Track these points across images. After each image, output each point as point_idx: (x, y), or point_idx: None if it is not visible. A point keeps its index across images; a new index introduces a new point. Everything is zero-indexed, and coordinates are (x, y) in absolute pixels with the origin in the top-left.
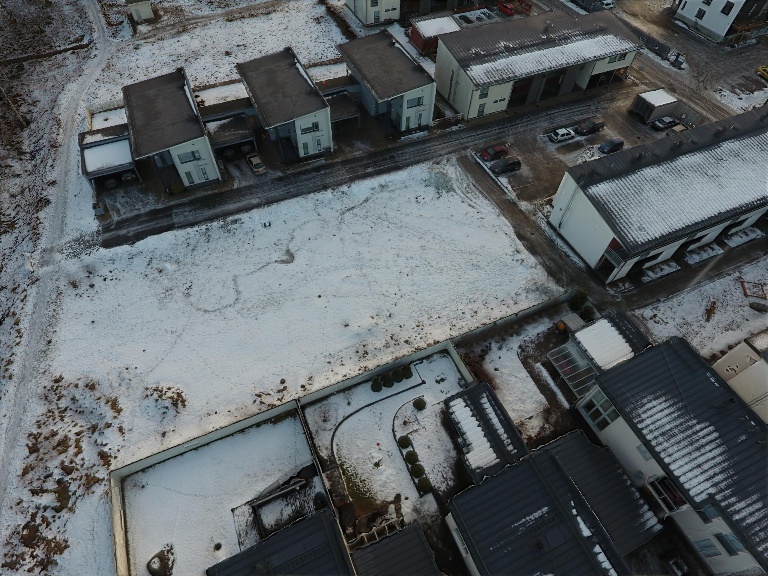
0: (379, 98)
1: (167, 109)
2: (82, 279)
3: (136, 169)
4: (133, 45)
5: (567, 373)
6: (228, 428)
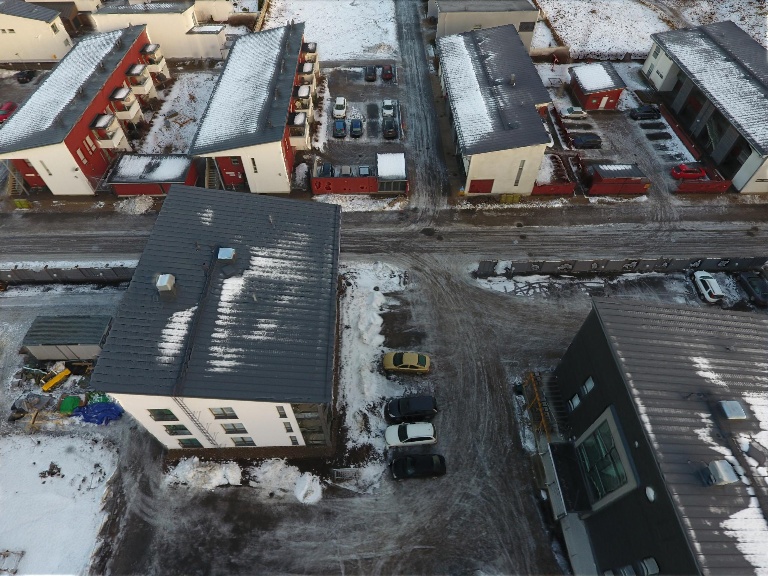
0: None
1: None
2: None
3: None
4: None
5: None
6: None
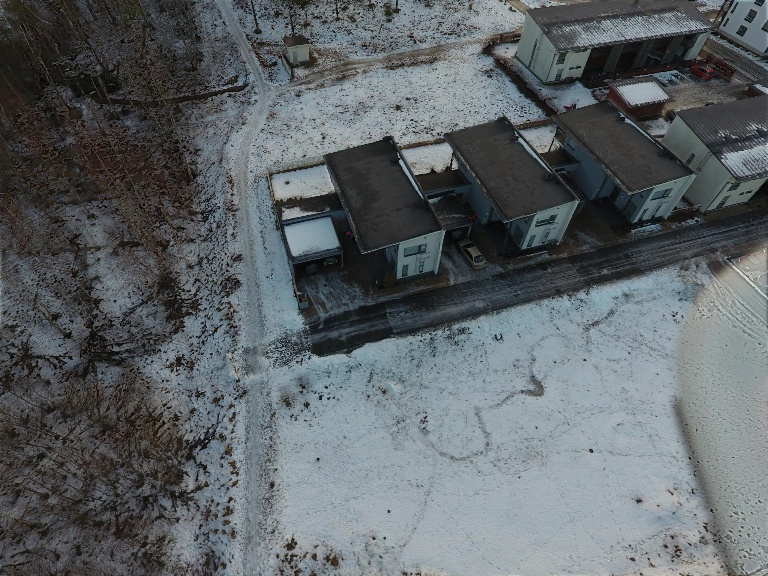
0: (628, 189)
1: (386, 189)
2: (295, 395)
3: (343, 255)
4: (294, 91)
5: None
6: None
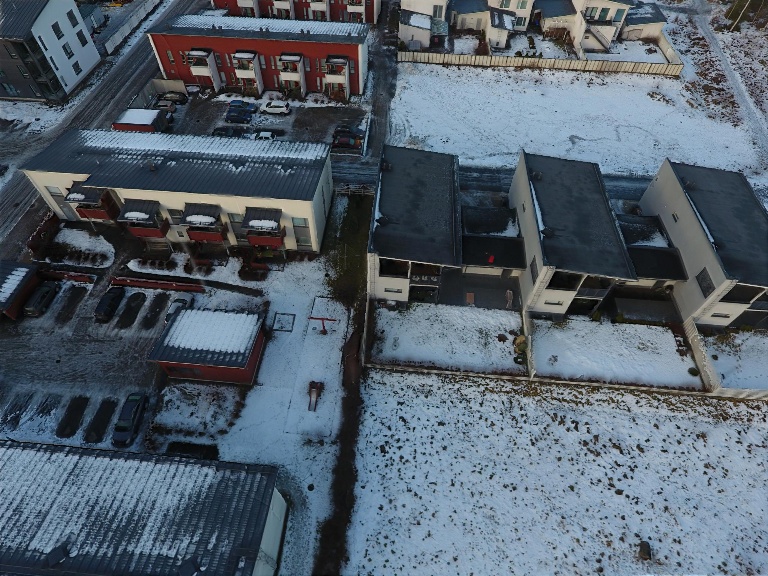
0: (455, 157)
1: (727, 216)
2: (752, 175)
3: None
4: None
5: (445, 27)
6: (624, 62)
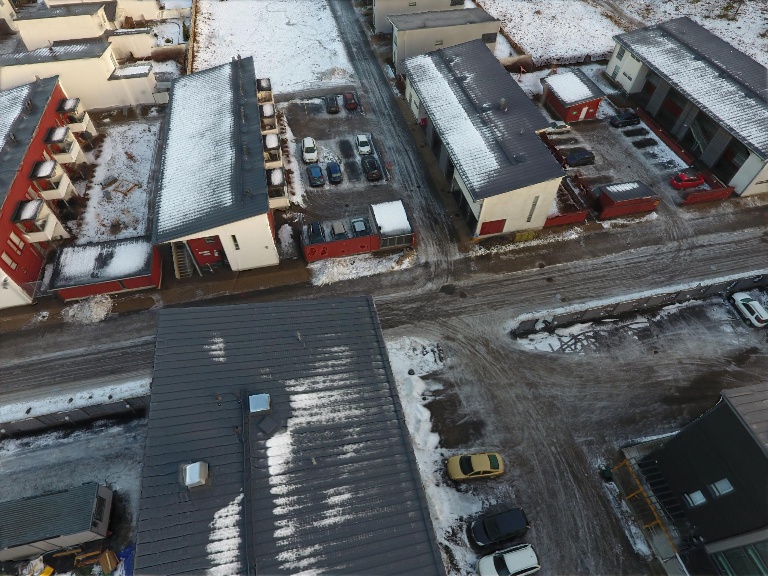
0: None
1: None
2: None
3: None
4: None
5: None
6: None
